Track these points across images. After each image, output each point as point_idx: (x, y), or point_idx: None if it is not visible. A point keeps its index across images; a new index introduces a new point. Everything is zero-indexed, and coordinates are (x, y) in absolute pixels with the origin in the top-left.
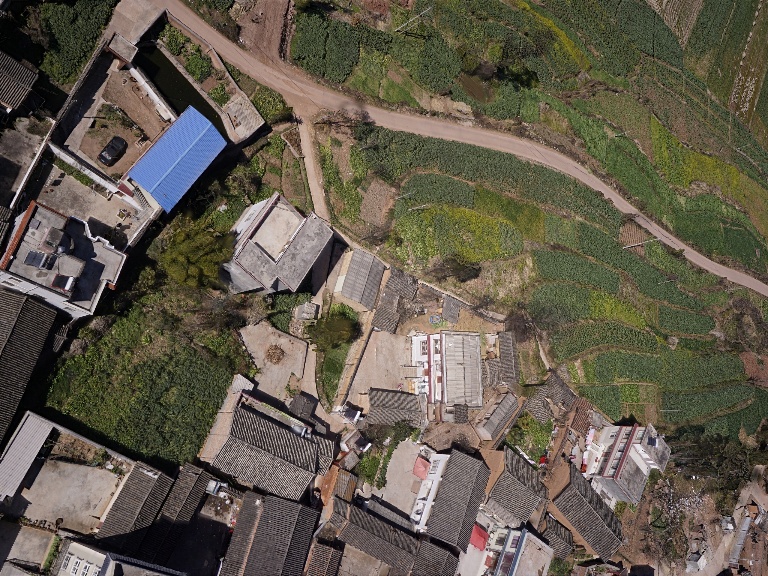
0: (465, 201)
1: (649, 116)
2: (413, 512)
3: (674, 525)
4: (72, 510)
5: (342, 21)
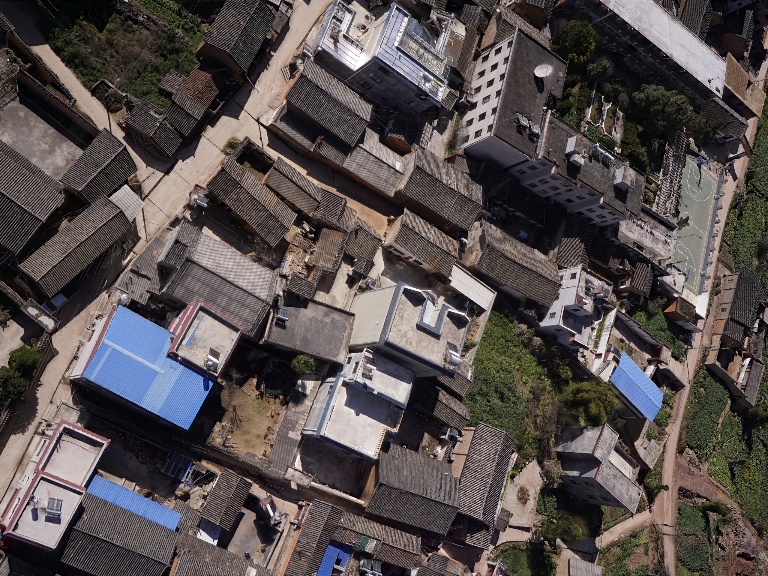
0: None
1: None
2: None
3: None
4: None
5: None
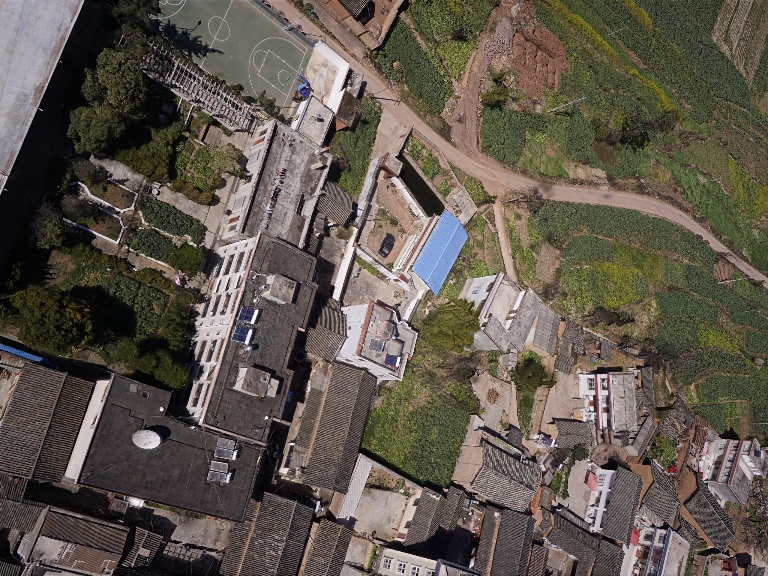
0: (607, 256)
1: (727, 157)
2: (586, 516)
3: (765, 519)
4: (380, 524)
5: (512, 109)
